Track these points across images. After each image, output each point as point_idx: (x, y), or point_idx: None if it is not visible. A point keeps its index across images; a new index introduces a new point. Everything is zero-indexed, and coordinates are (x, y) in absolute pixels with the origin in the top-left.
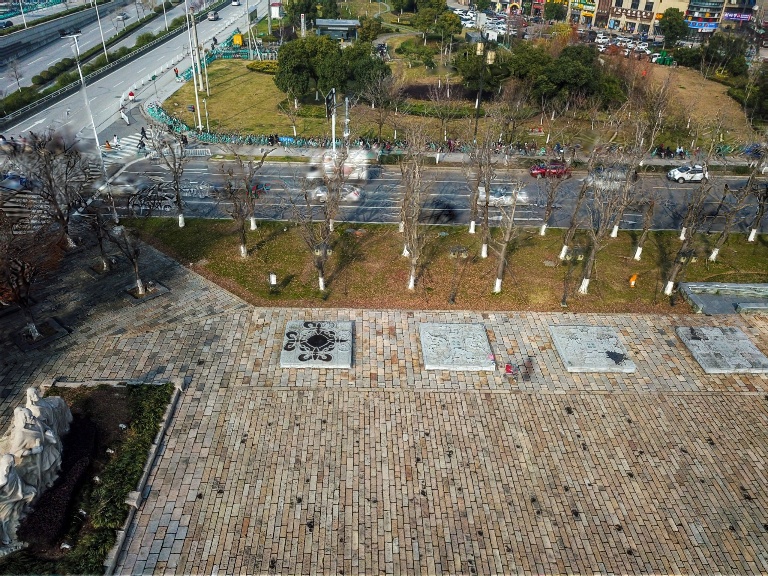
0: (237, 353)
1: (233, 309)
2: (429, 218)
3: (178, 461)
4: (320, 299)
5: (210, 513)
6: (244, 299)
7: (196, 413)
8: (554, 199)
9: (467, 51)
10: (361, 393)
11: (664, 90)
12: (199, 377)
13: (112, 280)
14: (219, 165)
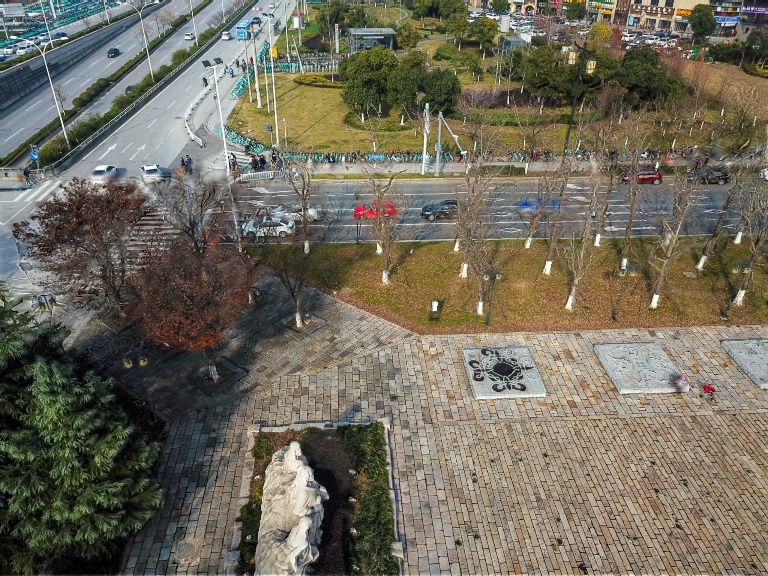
0: (425, 386)
1: (400, 339)
2: (544, 232)
3: (419, 506)
4: (482, 324)
5: (477, 560)
6: (405, 328)
7: (414, 453)
8: (656, 206)
9: (559, 61)
10: (568, 422)
11: (755, 91)
12: (399, 414)
13: (263, 314)
14: (311, 185)
